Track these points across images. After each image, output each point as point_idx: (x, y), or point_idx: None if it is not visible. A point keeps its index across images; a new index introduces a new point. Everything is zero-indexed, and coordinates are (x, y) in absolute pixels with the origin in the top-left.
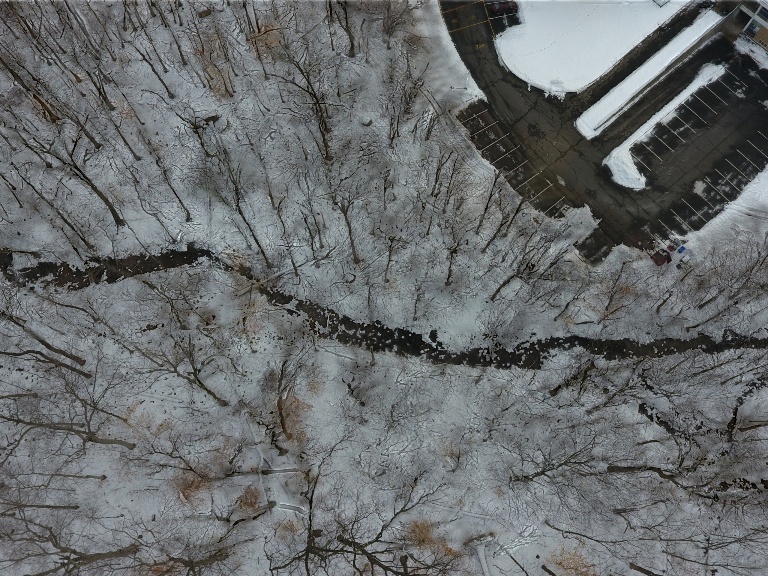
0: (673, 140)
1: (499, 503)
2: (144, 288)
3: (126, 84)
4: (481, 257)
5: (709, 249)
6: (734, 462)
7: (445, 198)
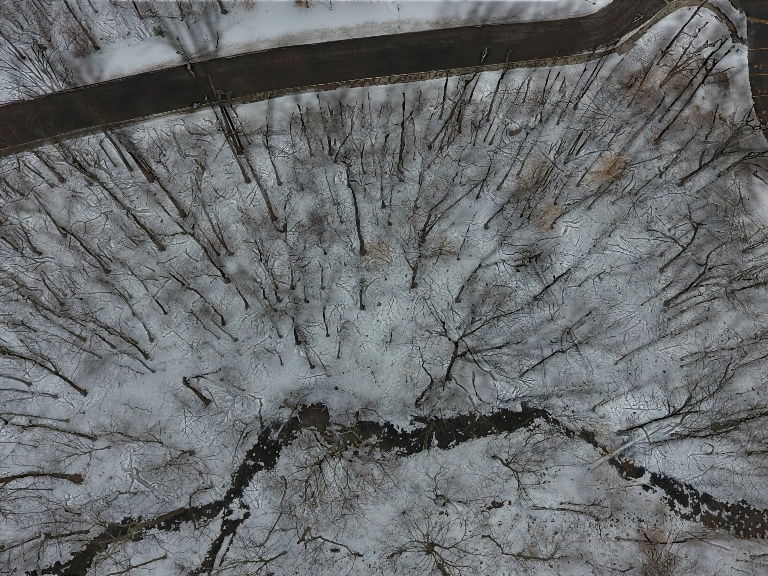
0: None
1: None
2: (486, 459)
3: (437, 213)
4: None
5: None
6: None
7: None
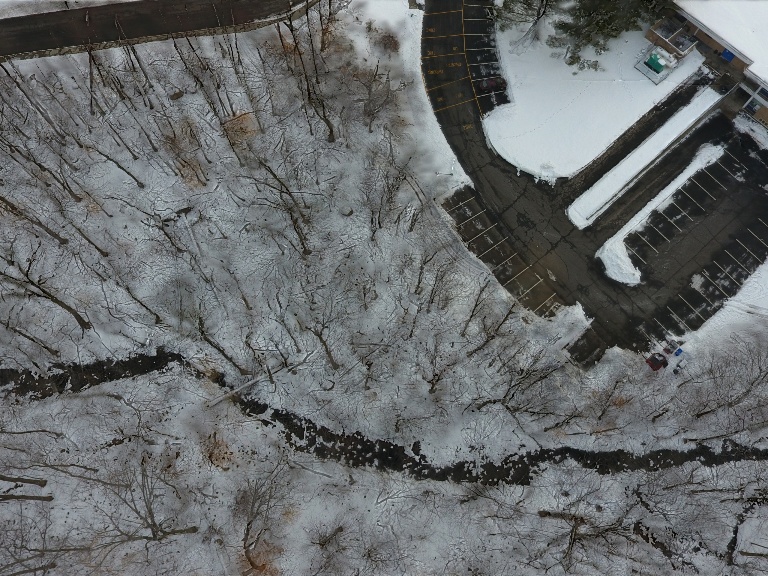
0: (669, 229)
1: None
2: (110, 399)
3: (93, 173)
4: (467, 361)
5: (707, 356)
6: None
7: (429, 299)
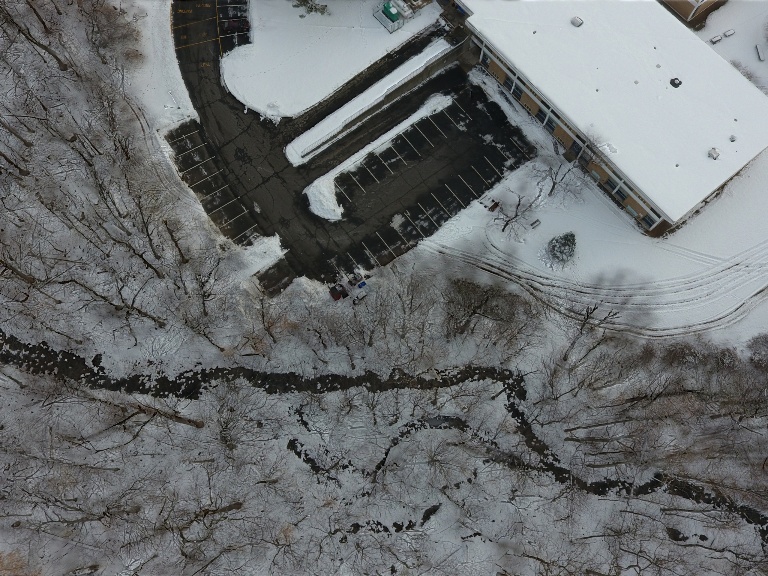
0: (381, 171)
1: (114, 535)
2: None
3: None
4: (158, 282)
5: None
6: (370, 504)
7: None
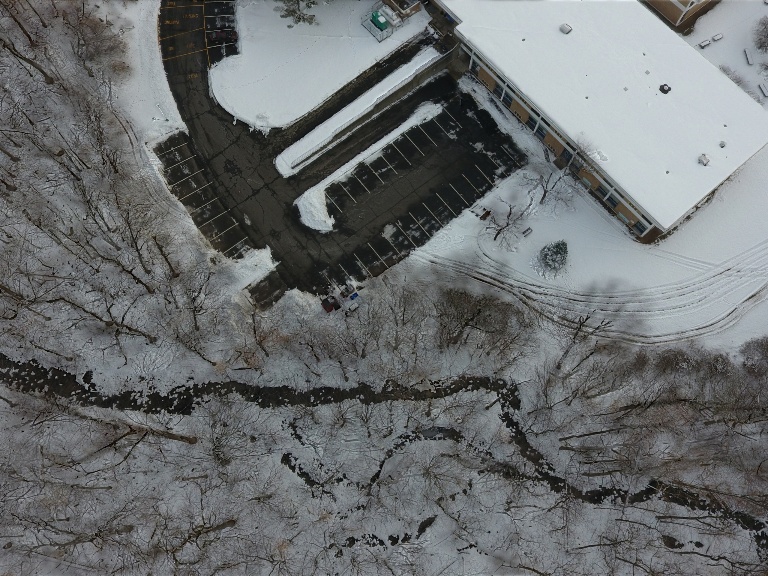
0: (372, 181)
1: (107, 554)
2: None
3: None
4: (148, 297)
5: None
6: (365, 517)
7: None
